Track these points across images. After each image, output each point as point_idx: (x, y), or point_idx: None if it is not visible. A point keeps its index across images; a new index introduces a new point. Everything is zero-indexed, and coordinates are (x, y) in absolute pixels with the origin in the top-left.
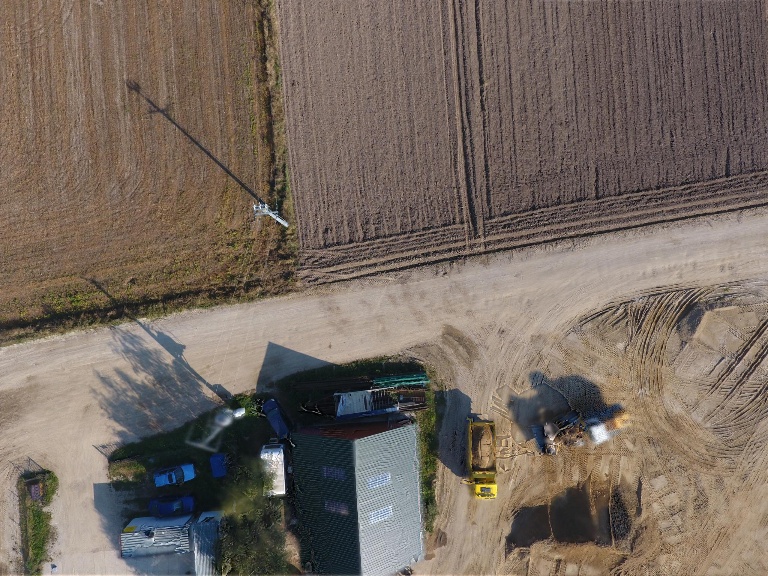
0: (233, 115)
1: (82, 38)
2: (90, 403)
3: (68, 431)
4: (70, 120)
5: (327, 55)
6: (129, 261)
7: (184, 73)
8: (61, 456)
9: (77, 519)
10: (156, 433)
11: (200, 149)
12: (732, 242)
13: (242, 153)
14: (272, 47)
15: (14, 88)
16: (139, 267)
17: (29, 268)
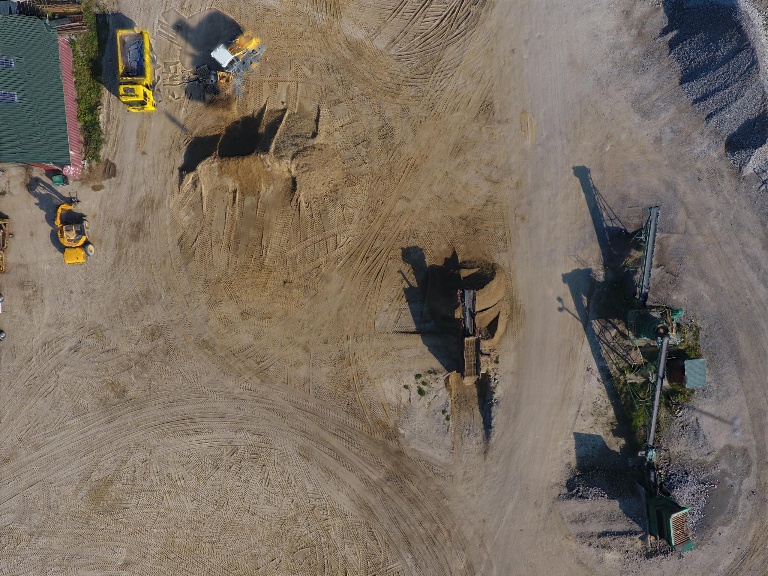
0: None
1: None
2: None
3: None
4: None
5: None
6: None
7: None
8: None
9: None
10: None
11: None
12: None
13: None
14: None
15: None
16: None
17: None
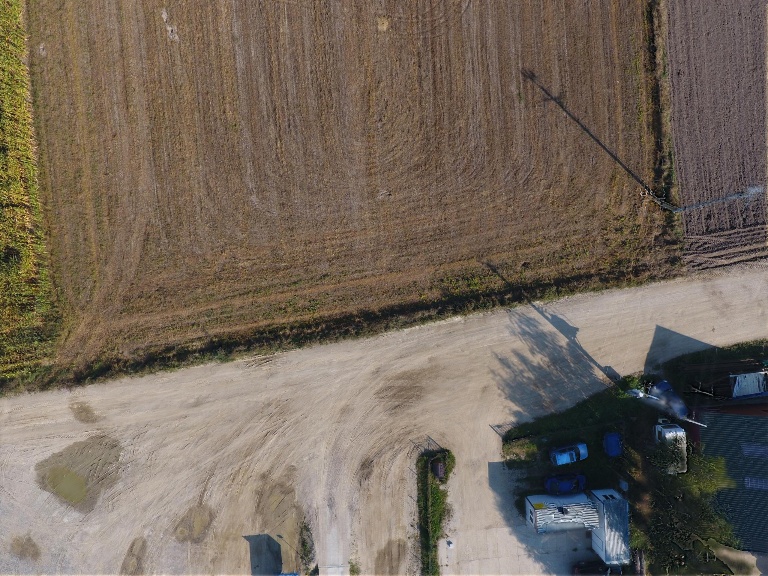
0: (622, 103)
1: (480, 27)
2: (488, 384)
3: (466, 411)
4: (467, 107)
5: (711, 45)
6: (522, 245)
7: (576, 62)
8: (459, 435)
9: (472, 497)
10: (549, 413)
11: (589, 136)
12: None
13: (629, 141)
14: (660, 37)
15: (416, 76)
16: (532, 251)
17: (429, 252)
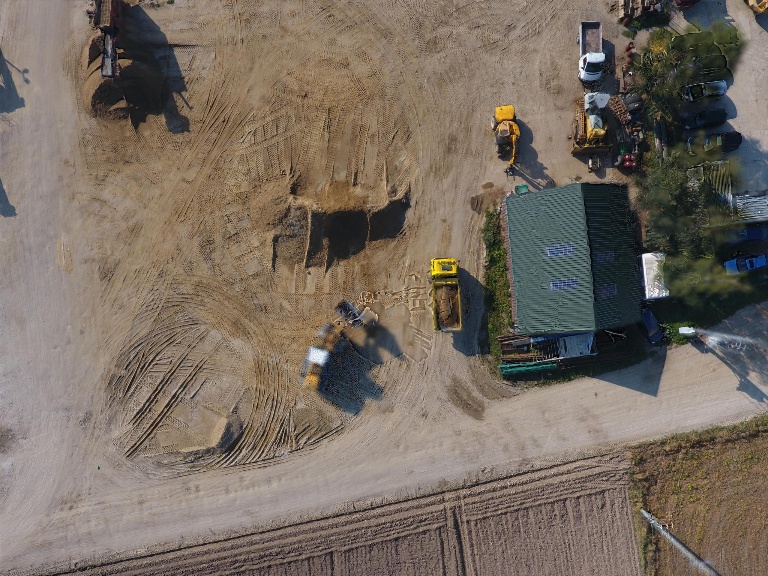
0: None
1: None
2: None
3: None
4: None
5: None
6: None
7: None
8: None
9: None
10: (762, 303)
11: None
12: (189, 516)
13: None
14: None
15: None
16: None
17: None
